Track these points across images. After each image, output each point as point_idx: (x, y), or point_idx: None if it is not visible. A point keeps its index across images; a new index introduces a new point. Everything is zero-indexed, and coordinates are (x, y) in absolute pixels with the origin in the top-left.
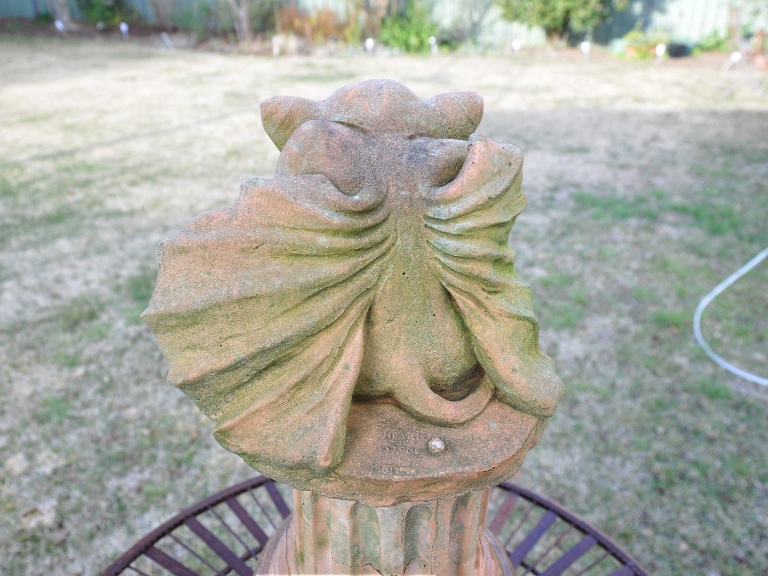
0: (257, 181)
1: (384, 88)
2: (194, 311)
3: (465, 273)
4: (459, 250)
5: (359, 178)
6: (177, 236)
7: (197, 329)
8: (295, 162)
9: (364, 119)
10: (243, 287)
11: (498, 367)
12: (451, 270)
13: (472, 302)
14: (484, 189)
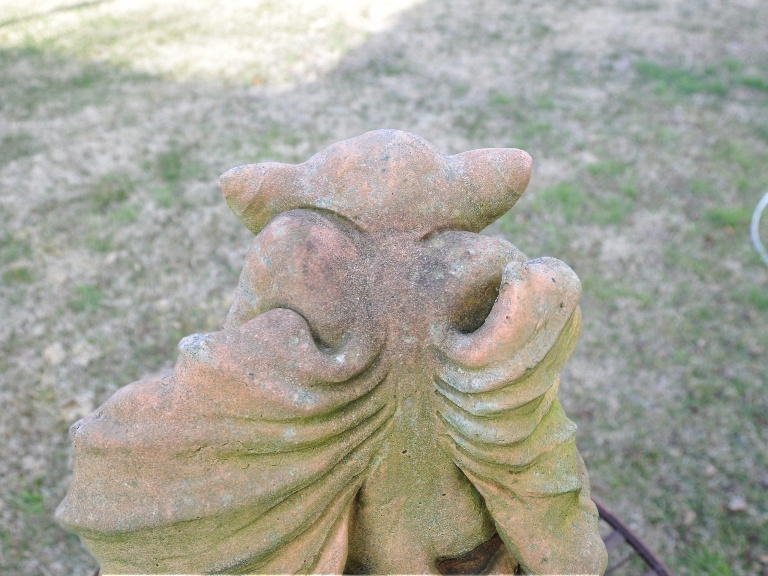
0: (198, 352)
1: (391, 159)
2: (117, 532)
3: (487, 460)
4: (480, 436)
5: (347, 320)
6: (91, 427)
7: (125, 546)
8: (262, 282)
9: (361, 210)
10: (179, 507)
11: (524, 556)
12: (468, 452)
13: (495, 486)
14: (521, 356)
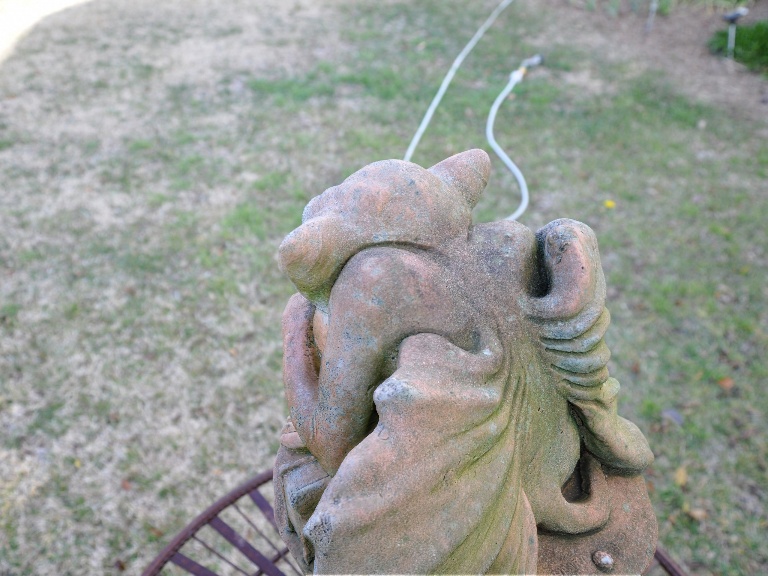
0: (410, 394)
1: (417, 182)
2: None
3: (595, 385)
4: (592, 367)
5: (469, 322)
6: (345, 512)
7: None
8: (378, 322)
9: (417, 232)
10: (451, 536)
11: (615, 451)
12: (579, 386)
13: (594, 406)
14: (598, 293)
